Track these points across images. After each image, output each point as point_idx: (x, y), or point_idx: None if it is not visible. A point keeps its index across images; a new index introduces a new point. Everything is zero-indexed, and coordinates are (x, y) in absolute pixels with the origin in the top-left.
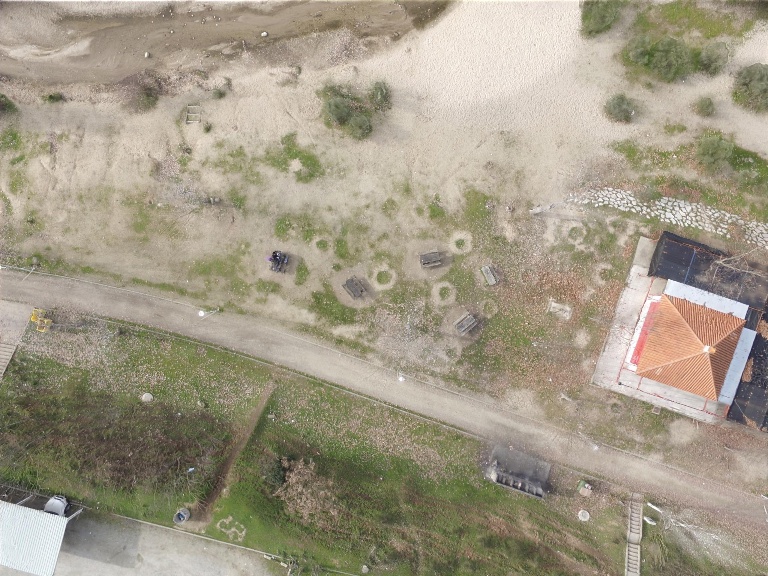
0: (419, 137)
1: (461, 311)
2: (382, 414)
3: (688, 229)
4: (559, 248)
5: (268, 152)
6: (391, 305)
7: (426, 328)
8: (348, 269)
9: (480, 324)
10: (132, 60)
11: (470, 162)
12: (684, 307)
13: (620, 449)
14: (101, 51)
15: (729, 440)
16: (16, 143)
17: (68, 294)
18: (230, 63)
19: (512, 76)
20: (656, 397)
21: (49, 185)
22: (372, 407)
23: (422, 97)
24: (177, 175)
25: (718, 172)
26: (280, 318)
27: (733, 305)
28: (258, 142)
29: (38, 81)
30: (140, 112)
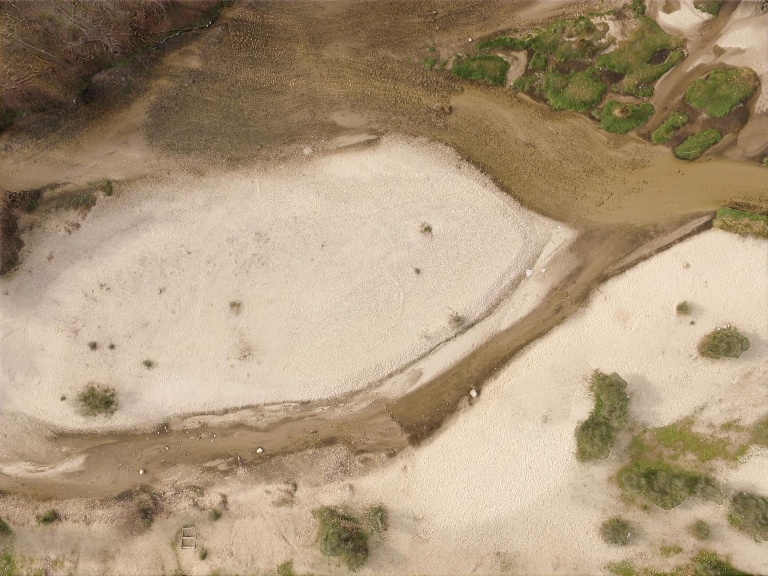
0: (415, 561)
1: None
2: None
3: None
4: None
5: None
6: None
7: None
8: None
9: None
10: (127, 476)
11: None
12: None
13: None
14: (96, 467)
15: None
16: (10, 569)
17: None
18: (226, 479)
19: (508, 498)
20: None
21: None
22: None
23: (418, 517)
24: None
25: None
26: None
27: None
28: (254, 571)
29: (32, 497)
30: (135, 534)
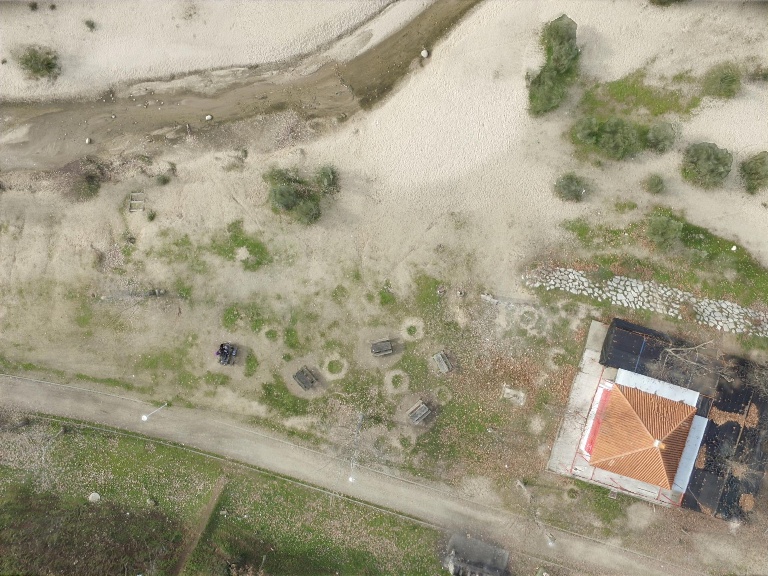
0: (369, 220)
1: (414, 399)
2: (337, 506)
3: (639, 311)
4: (511, 333)
5: (214, 240)
6: (343, 395)
7: (379, 417)
8: (298, 359)
9: (434, 411)
10: (73, 146)
11: (421, 245)
12: (635, 397)
13: (578, 534)
14: (40, 138)
15: (686, 522)
16: None
17: (10, 393)
18: (174, 147)
19: (461, 156)
20: (612, 482)
21: None
22: (326, 499)
23: (371, 179)
24: (121, 266)
25: (669, 249)
26: (230, 411)
27: (684, 393)
28: (204, 230)
29: None
30: (82, 201)
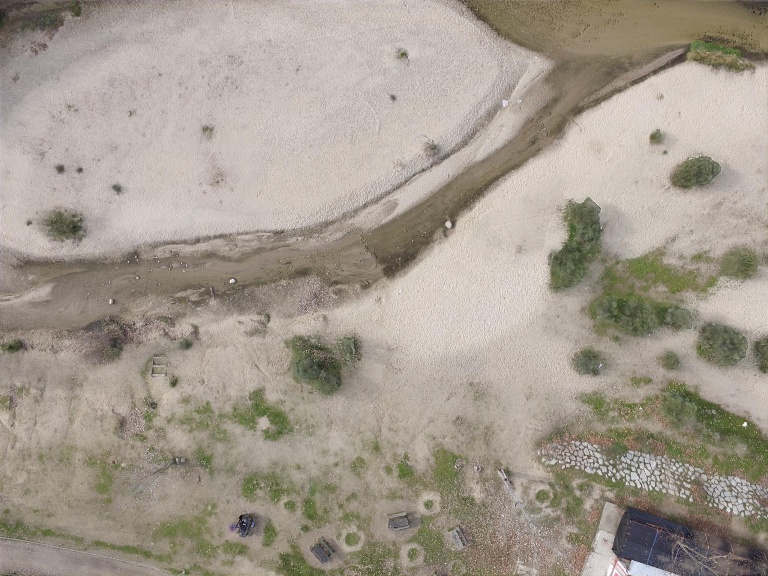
0: (389, 390)
1: (429, 572)
2: None
3: (652, 493)
4: (526, 511)
5: (235, 409)
6: (359, 566)
7: None
8: (316, 530)
9: None
10: (96, 306)
11: (439, 417)
12: None
13: None
14: (64, 297)
15: None
16: None
17: (28, 558)
18: (197, 310)
19: (482, 328)
20: None
21: (8, 444)
22: None
23: (392, 347)
24: (142, 433)
25: (682, 424)
26: None
27: None
28: (225, 397)
29: None
30: (104, 363)
